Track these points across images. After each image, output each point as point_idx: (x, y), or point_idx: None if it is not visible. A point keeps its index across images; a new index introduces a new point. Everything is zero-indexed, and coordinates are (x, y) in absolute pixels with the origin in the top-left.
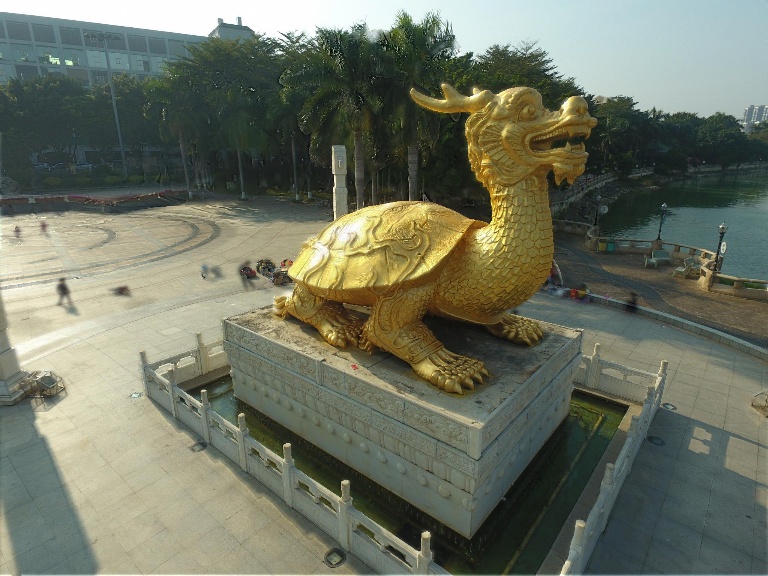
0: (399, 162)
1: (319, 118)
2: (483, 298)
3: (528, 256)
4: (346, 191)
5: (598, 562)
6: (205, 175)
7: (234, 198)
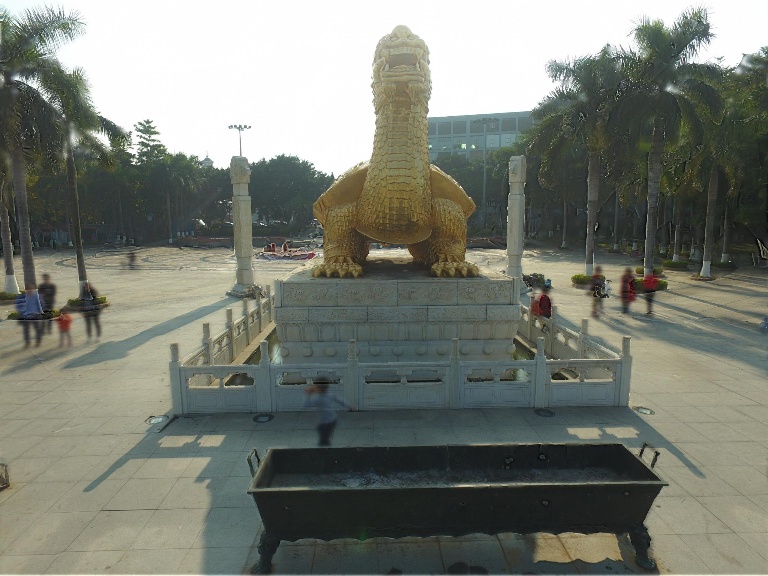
0: (689, 191)
1: (549, 142)
2: (365, 212)
3: (377, 169)
4: (519, 198)
5: (311, 414)
6: (531, 224)
7: (554, 246)
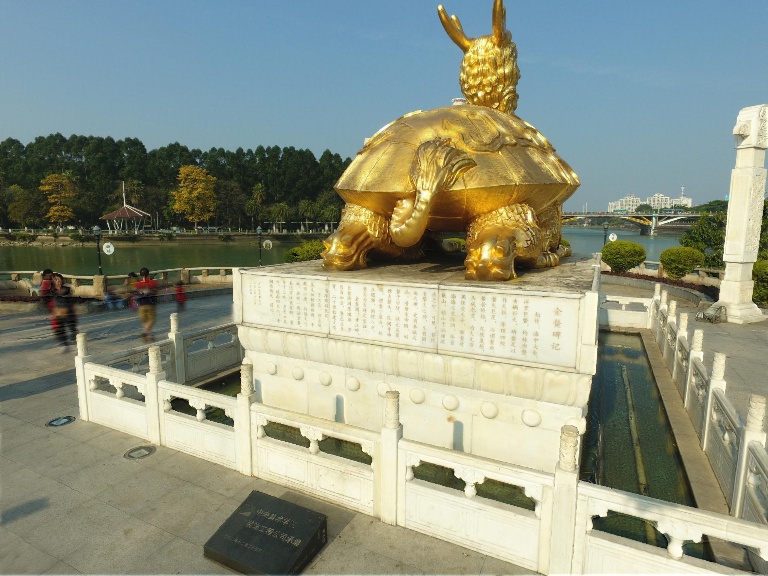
0: None
1: None
2: None
3: None
4: None
5: None
6: None
7: None
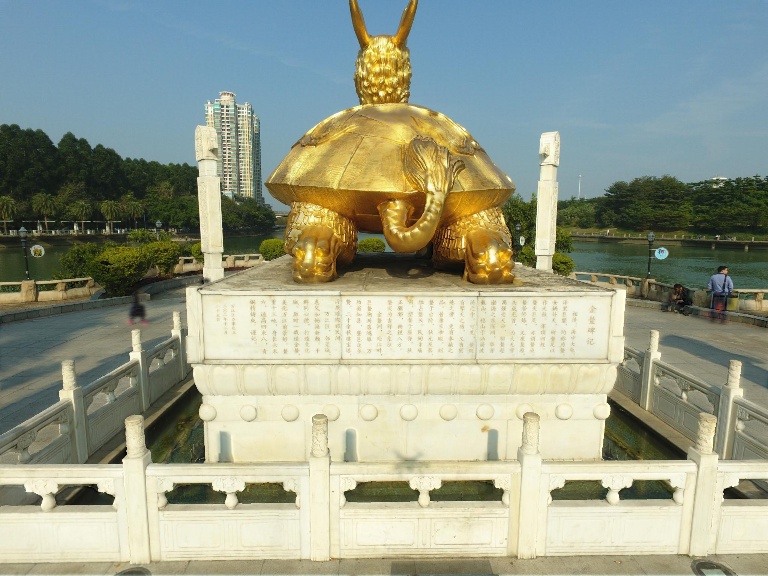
0: None
1: None
2: None
3: None
4: None
5: None
6: None
7: None
